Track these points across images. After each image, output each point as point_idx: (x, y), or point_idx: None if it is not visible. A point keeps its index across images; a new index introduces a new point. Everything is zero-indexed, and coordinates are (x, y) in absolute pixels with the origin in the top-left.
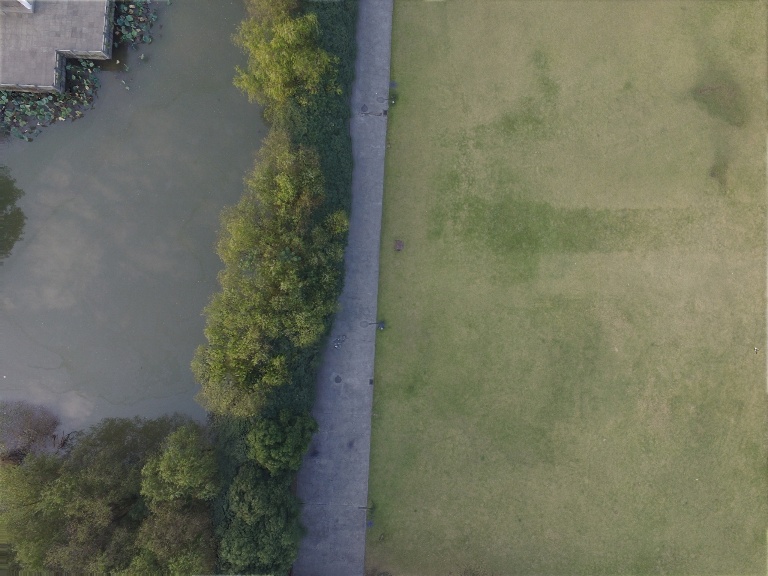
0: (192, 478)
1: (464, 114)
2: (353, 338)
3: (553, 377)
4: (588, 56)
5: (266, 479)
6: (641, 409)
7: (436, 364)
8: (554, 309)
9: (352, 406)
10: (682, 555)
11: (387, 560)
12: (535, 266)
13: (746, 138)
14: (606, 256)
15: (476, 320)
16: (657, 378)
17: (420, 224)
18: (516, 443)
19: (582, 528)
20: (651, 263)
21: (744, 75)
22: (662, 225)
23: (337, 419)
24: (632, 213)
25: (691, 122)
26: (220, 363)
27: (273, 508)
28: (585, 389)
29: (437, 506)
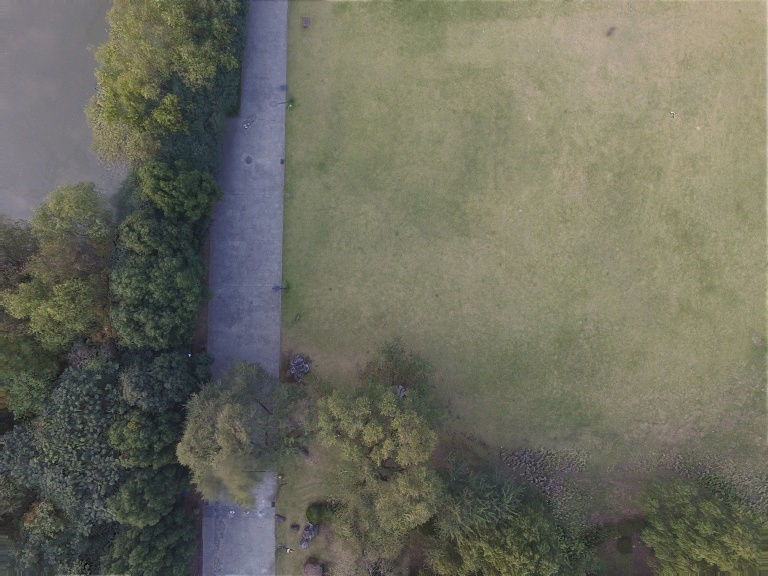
0: (81, 210)
1: None
2: (263, 118)
3: (465, 148)
4: None
5: (159, 217)
6: (557, 178)
7: (347, 140)
8: (464, 79)
9: (264, 186)
10: (605, 328)
11: (303, 340)
12: (442, 35)
13: None
14: (514, 23)
15: (385, 93)
16: (572, 146)
17: None
18: (430, 217)
19: (501, 302)
20: (561, 28)
21: None
22: None
23: (249, 200)
24: None
25: None
26: (111, 104)
27: (168, 248)
28: (498, 159)
29: (352, 283)
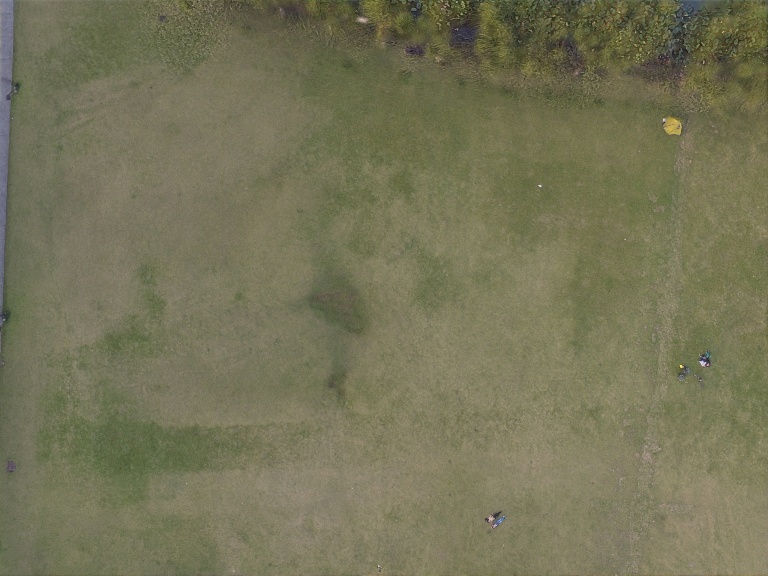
0: None
1: (67, 334)
2: None
3: None
4: (197, 267)
5: None
6: None
7: None
8: (167, 530)
9: None
10: None
11: None
12: (144, 487)
13: (364, 346)
14: (218, 475)
15: (89, 542)
16: None
17: (30, 446)
18: None
19: None
20: (265, 481)
21: (362, 280)
22: (276, 441)
23: None
24: (244, 429)
25: (307, 331)
26: None
27: None
28: None
29: None
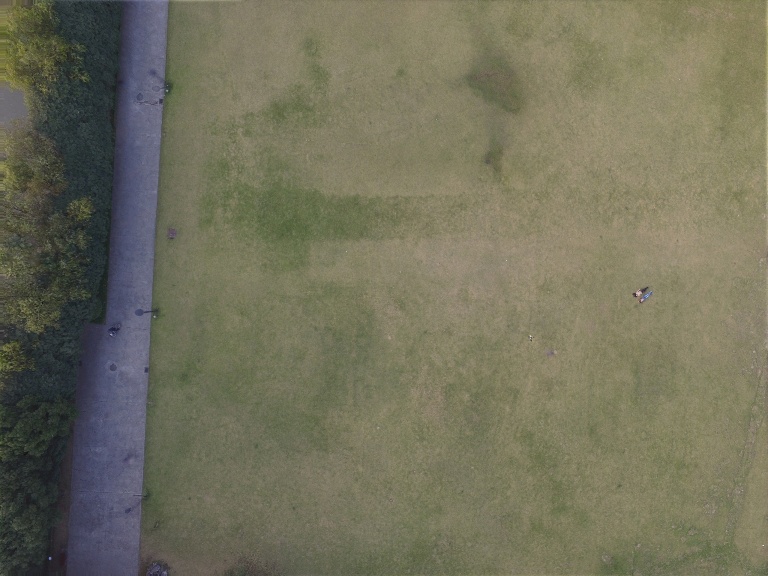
0: None
1: (233, 102)
2: (128, 326)
3: (326, 365)
4: (361, 43)
5: None
6: (415, 397)
7: (210, 352)
8: (326, 297)
9: (127, 394)
10: (458, 544)
11: (162, 548)
12: (305, 254)
13: (521, 125)
14: (377, 244)
15: (248, 308)
16: (431, 366)
17: (192, 212)
18: (290, 431)
19: (357, 516)
20: (423, 250)
21: (520, 61)
22: (434, 212)
23: (112, 407)
24: (404, 200)
25: (466, 109)
26: None
27: (5, 493)
28: (358, 377)
29: (211, 494)
